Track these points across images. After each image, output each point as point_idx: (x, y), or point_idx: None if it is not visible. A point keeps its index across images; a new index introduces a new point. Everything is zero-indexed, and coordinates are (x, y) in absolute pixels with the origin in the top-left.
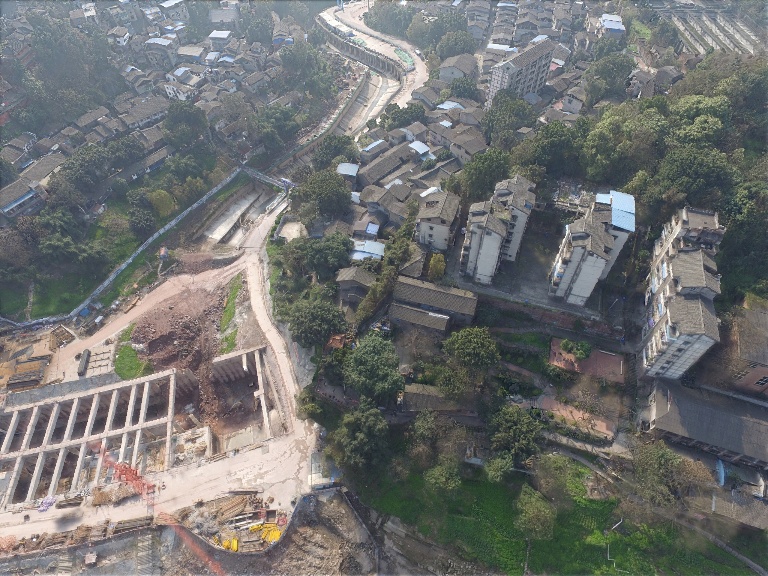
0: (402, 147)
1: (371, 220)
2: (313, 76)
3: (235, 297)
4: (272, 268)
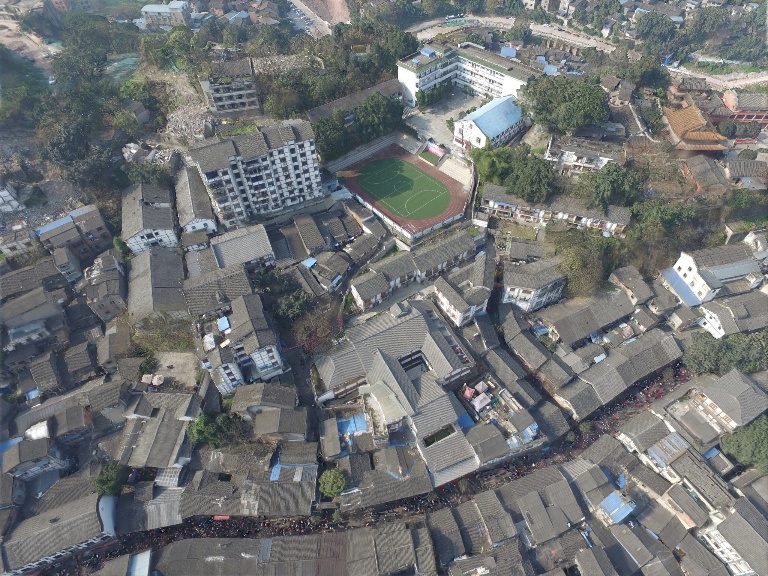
0: (644, 3)
1: (733, 6)
2: (537, 37)
3: (767, 86)
4: (741, 70)
